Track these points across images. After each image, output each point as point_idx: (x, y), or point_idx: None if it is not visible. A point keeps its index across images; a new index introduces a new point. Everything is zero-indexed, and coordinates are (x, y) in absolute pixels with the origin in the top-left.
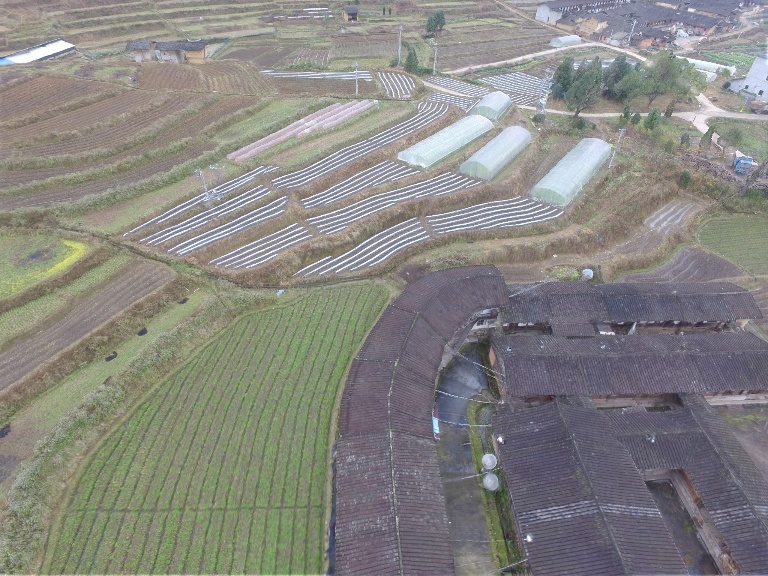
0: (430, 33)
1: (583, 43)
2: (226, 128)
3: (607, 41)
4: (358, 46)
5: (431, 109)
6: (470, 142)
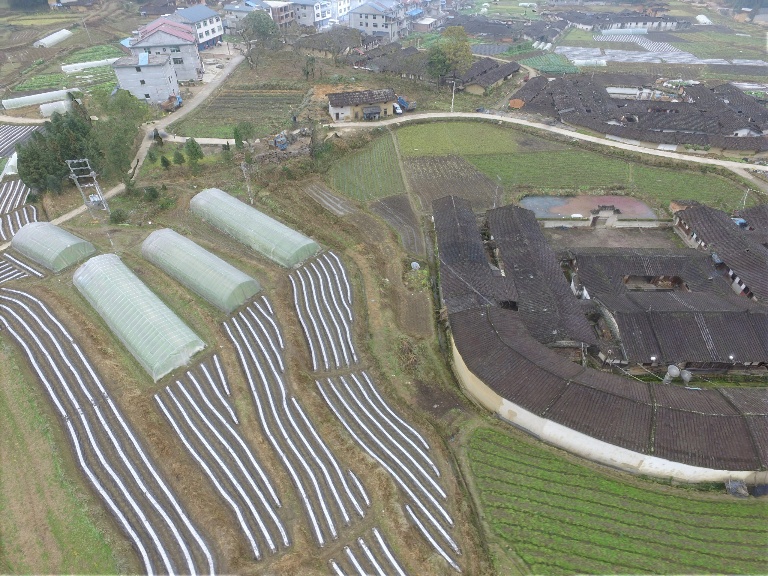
0: None
1: None
2: None
3: None
4: None
5: None
6: None
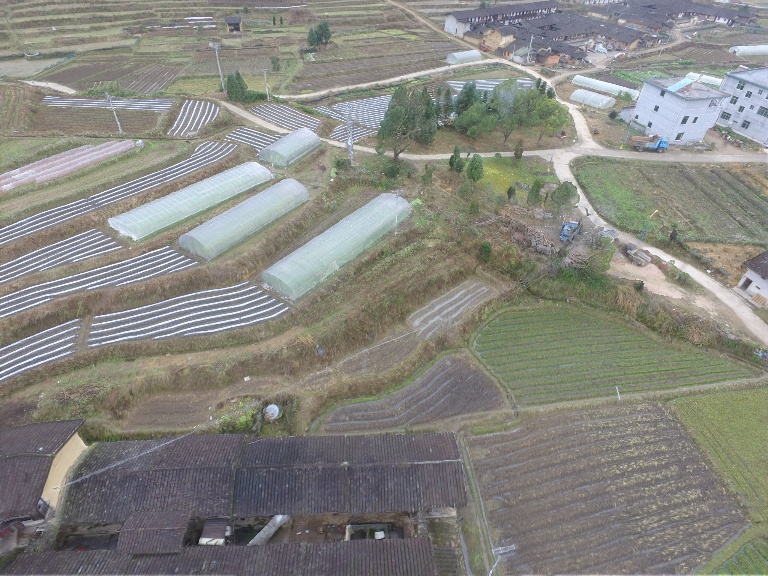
0: (311, 47)
1: (484, 59)
2: None
3: (510, 57)
4: None
5: (211, 151)
6: (227, 200)
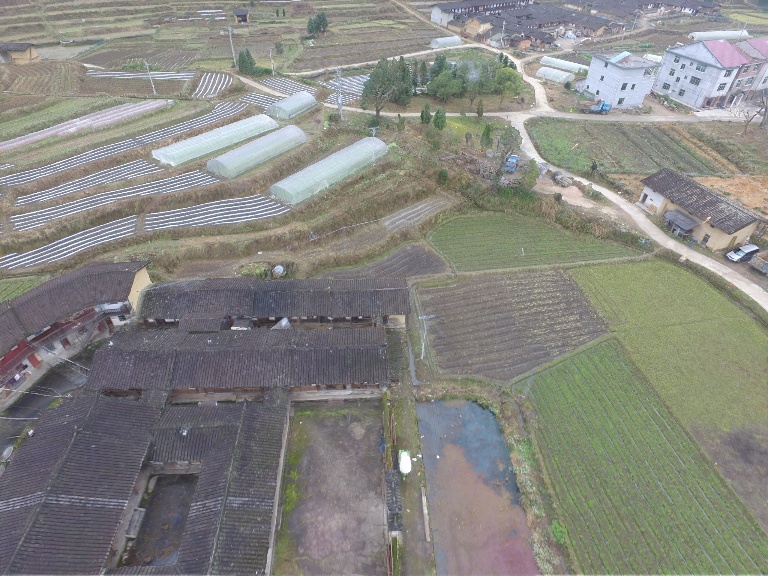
0: (310, 34)
1: (464, 44)
2: None
3: (488, 42)
4: (228, 47)
5: None
6: (242, 141)
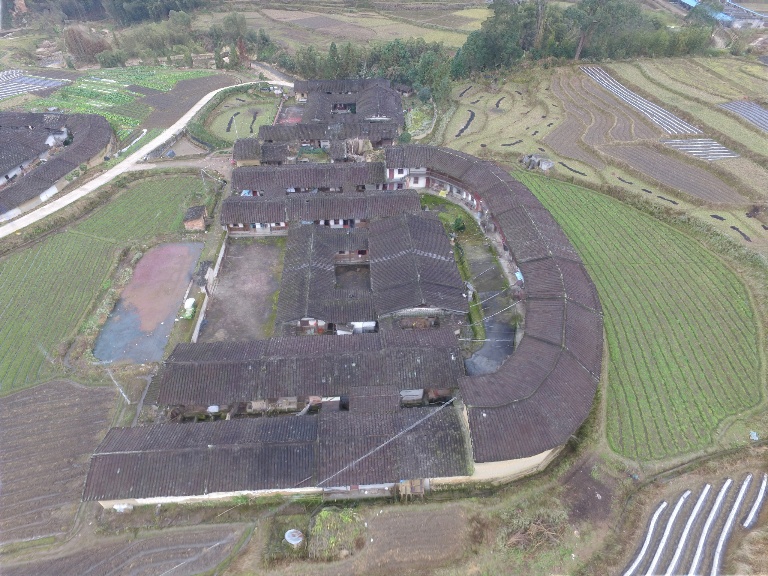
0: None
1: None
2: None
3: None
4: None
5: None
6: None
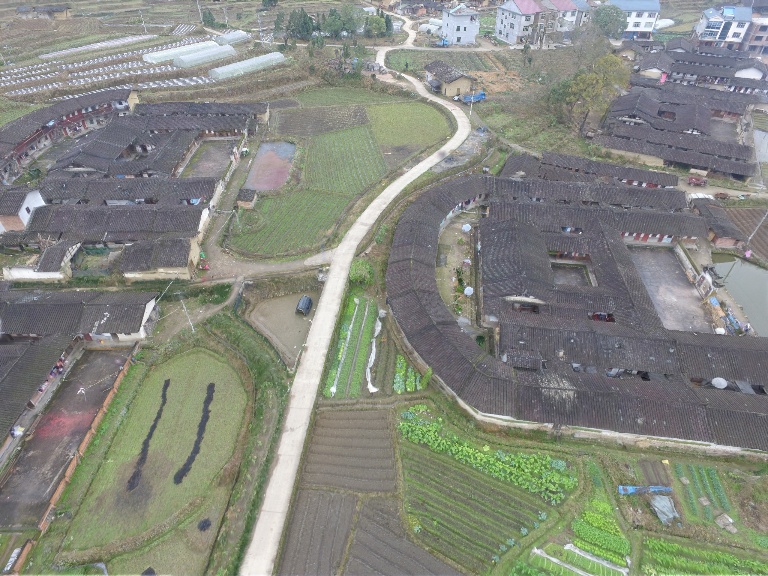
0: (264, 8)
1: None
2: (48, 46)
3: (395, 11)
4: None
5: None
6: None
